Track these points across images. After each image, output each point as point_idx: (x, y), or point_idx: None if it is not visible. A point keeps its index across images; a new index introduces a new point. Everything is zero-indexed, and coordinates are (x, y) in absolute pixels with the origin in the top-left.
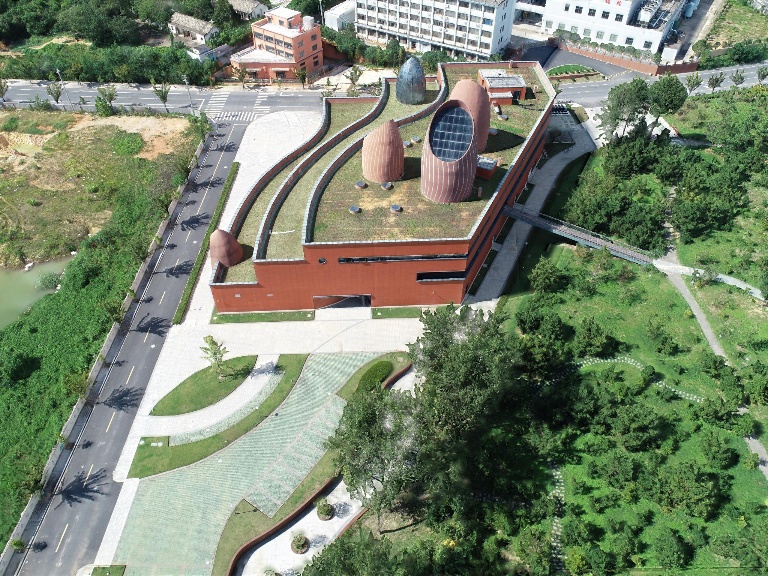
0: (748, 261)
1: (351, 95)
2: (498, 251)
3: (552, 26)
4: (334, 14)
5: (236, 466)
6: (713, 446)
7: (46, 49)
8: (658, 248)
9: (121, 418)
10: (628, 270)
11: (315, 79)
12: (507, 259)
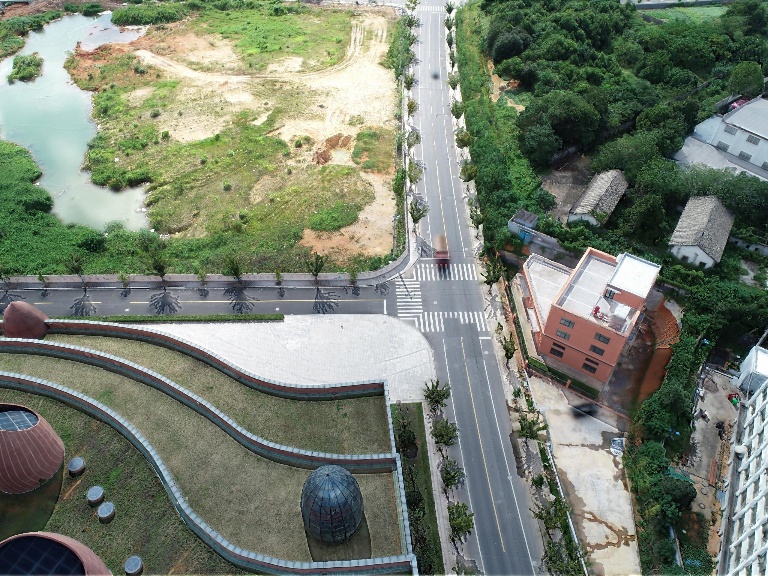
0: None
1: None
2: None
3: None
4: (754, 362)
5: None
6: None
7: (505, 109)
8: None
9: None
10: None
11: (545, 376)
12: None
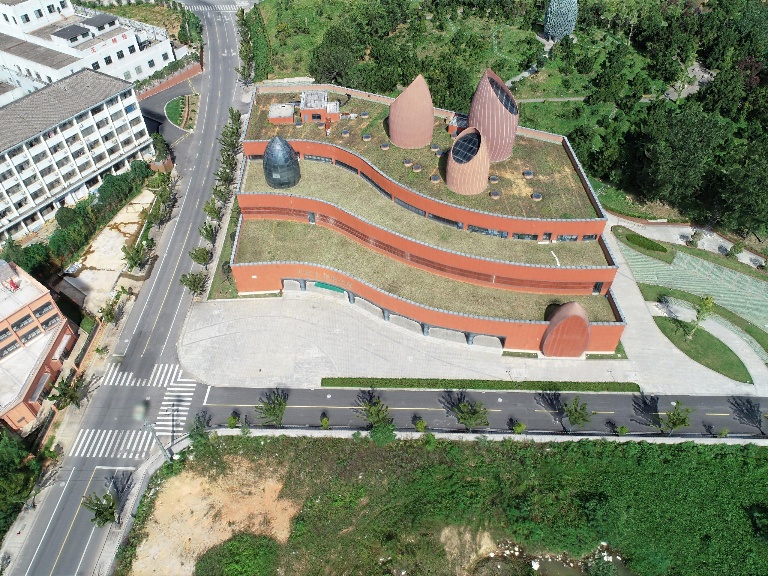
0: None
1: (201, 254)
2: None
3: None
4: None
5: (765, 315)
6: (663, 103)
7: None
8: None
9: (767, 408)
10: None
11: None
12: None
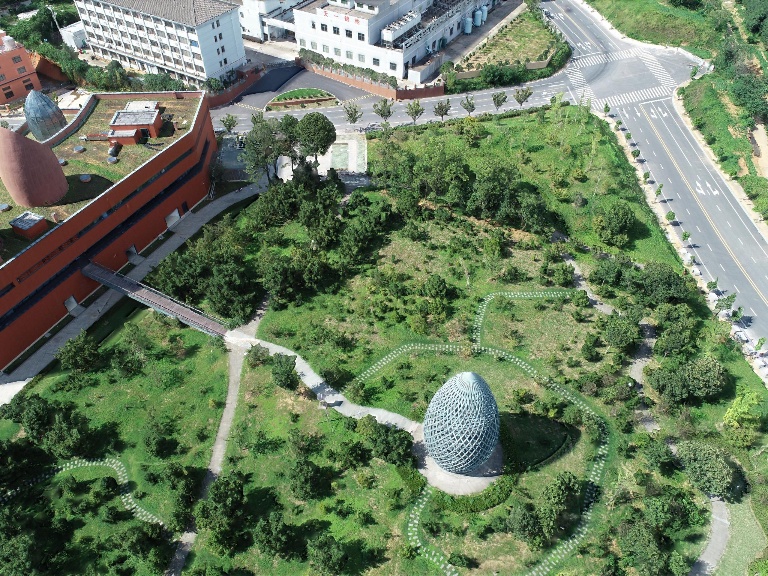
0: (329, 333)
1: None
2: (75, 317)
3: (306, 44)
4: (68, 31)
5: None
6: None
7: None
8: (237, 316)
9: None
10: (177, 346)
11: (21, 105)
12: (79, 327)
